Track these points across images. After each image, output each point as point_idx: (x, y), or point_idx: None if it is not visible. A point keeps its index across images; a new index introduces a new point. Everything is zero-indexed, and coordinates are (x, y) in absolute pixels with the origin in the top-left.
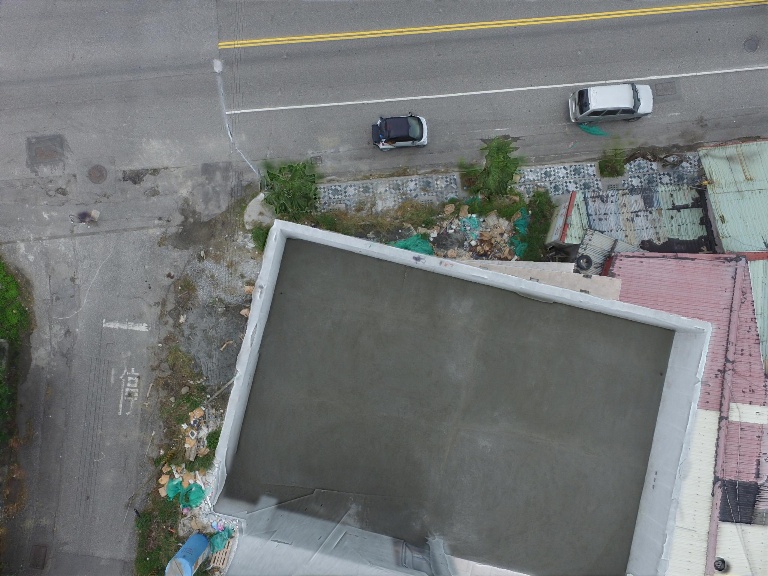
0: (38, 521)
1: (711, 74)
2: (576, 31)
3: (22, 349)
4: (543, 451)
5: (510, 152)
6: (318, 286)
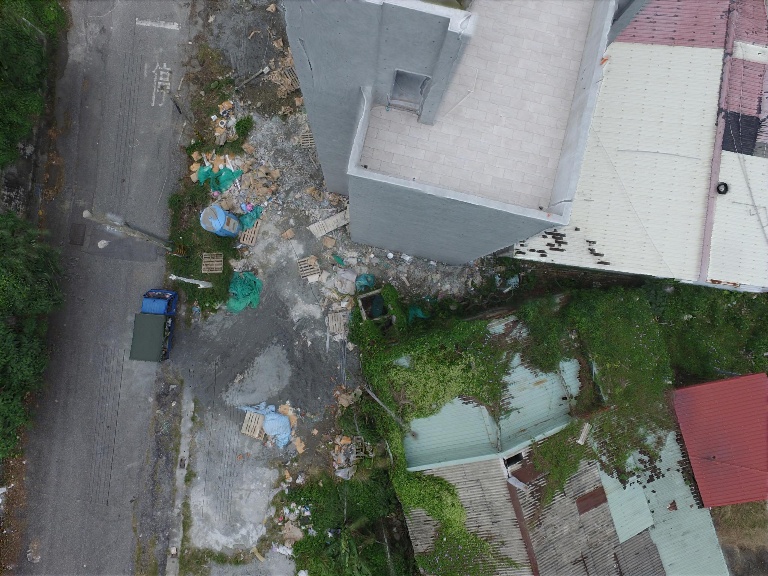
0: (77, 202)
1: None
2: None
3: (59, 46)
4: None
5: None
6: None
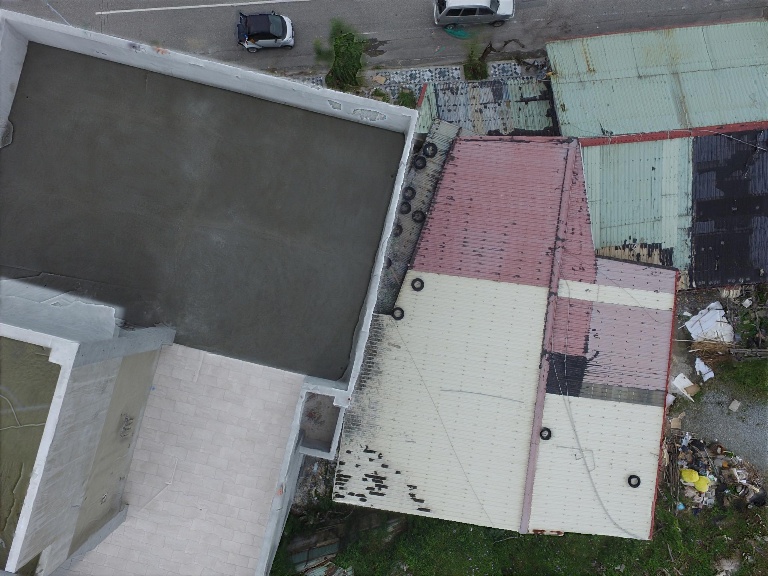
0: None
1: None
2: None
3: None
4: (276, 248)
5: (377, 55)
6: (63, 90)
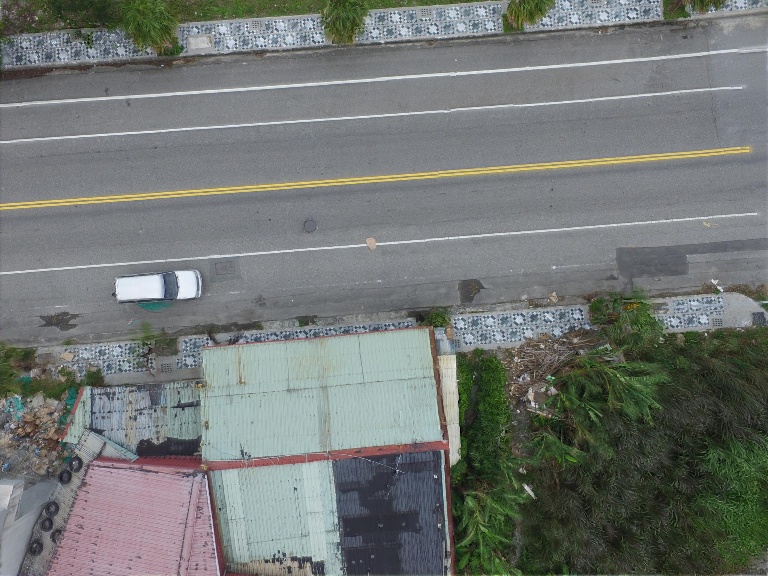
0: None
1: (271, 254)
2: (137, 210)
3: None
4: None
5: (68, 329)
6: None
